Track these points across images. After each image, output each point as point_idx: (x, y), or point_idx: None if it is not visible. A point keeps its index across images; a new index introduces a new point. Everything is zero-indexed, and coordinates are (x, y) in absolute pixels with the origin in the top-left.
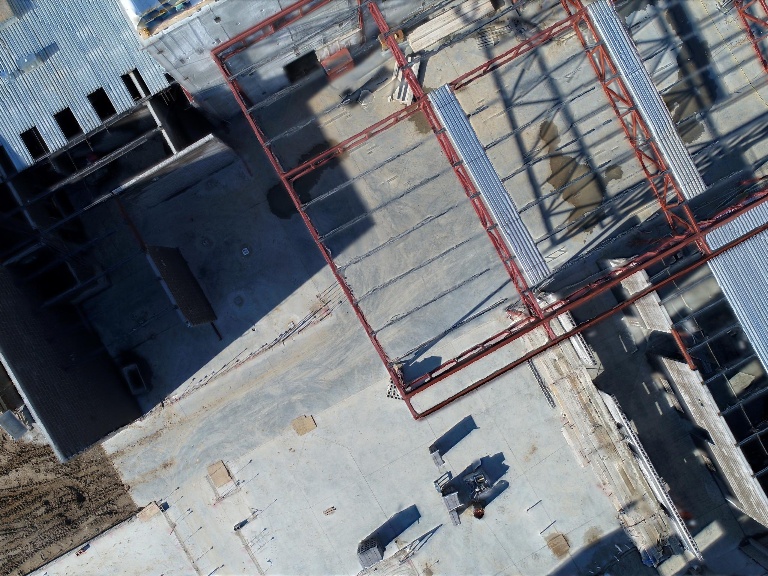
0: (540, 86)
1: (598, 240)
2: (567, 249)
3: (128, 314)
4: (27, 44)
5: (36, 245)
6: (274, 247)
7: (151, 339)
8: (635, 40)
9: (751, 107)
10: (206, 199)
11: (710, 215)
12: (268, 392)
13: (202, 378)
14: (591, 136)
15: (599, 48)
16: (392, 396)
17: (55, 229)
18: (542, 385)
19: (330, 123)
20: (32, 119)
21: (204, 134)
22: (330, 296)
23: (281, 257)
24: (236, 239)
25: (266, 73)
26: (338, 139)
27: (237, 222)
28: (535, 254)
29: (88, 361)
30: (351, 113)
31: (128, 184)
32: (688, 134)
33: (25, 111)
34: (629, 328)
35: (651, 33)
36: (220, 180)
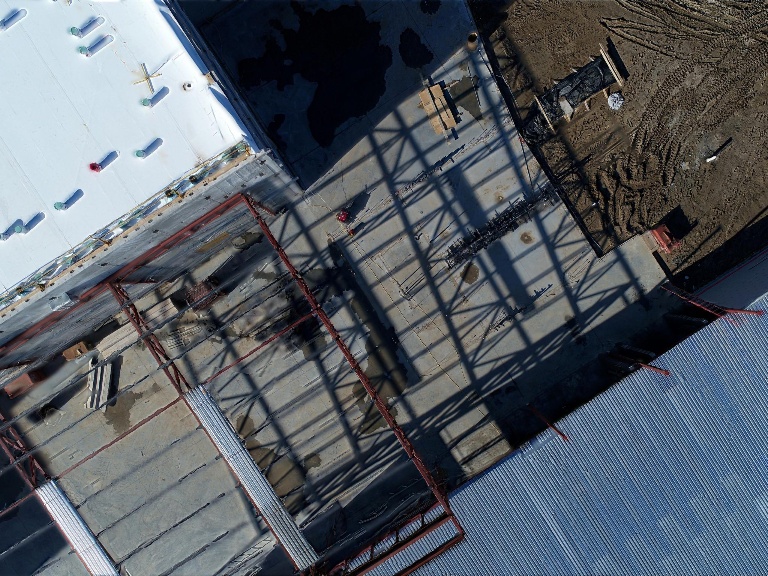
0: (233, 382)
1: None
2: (272, 538)
3: None
4: None
5: None
6: None
7: None
8: (323, 331)
9: (442, 388)
10: None
11: (354, 553)
12: None
13: None
14: (287, 427)
15: None
16: None
17: None
18: None
19: (30, 432)
20: None
21: None
22: None
23: None
24: None
25: None
26: None
27: None
28: None
29: None
30: None
31: None
32: (382, 419)
33: None
34: None
35: (338, 323)
36: None
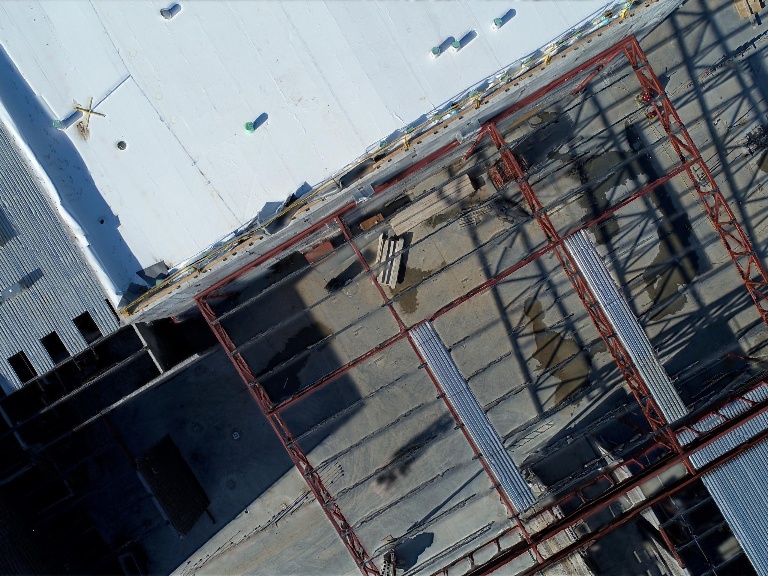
0: None
1: (585, 413)
2: (555, 423)
3: (121, 501)
4: (11, 270)
5: (27, 466)
6: (264, 430)
7: (145, 525)
8: (616, 215)
9: (733, 277)
10: (195, 385)
11: (693, 419)
12: (263, 573)
13: (197, 561)
14: (575, 311)
15: (577, 276)
16: (386, 575)
17: (45, 449)
18: (534, 558)
19: (316, 306)
20: (19, 343)
21: (191, 330)
22: (321, 476)
23: (271, 440)
24: (226, 424)
25: (250, 277)
26: (324, 322)
27: (227, 407)
28: (520, 482)
29: (83, 563)
30: (336, 296)
31: (116, 404)
32: (671, 306)
33: (12, 336)
34: (619, 498)
35: (631, 207)
36: (208, 366)
